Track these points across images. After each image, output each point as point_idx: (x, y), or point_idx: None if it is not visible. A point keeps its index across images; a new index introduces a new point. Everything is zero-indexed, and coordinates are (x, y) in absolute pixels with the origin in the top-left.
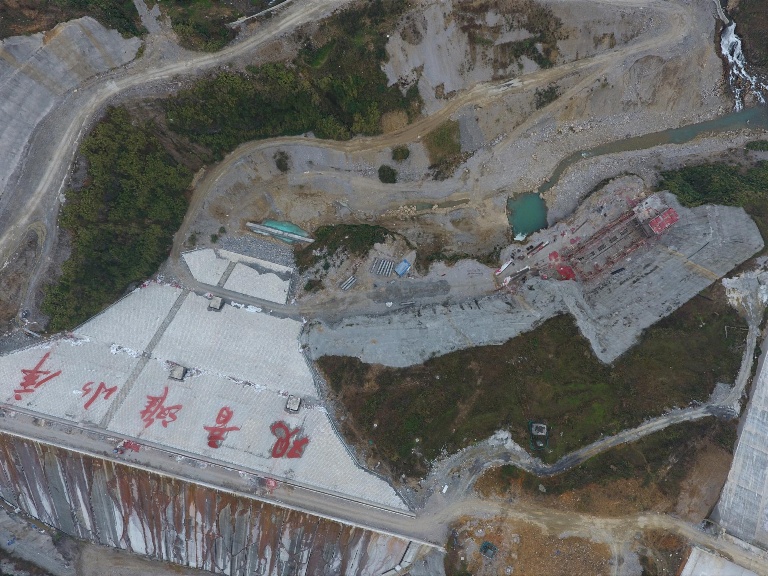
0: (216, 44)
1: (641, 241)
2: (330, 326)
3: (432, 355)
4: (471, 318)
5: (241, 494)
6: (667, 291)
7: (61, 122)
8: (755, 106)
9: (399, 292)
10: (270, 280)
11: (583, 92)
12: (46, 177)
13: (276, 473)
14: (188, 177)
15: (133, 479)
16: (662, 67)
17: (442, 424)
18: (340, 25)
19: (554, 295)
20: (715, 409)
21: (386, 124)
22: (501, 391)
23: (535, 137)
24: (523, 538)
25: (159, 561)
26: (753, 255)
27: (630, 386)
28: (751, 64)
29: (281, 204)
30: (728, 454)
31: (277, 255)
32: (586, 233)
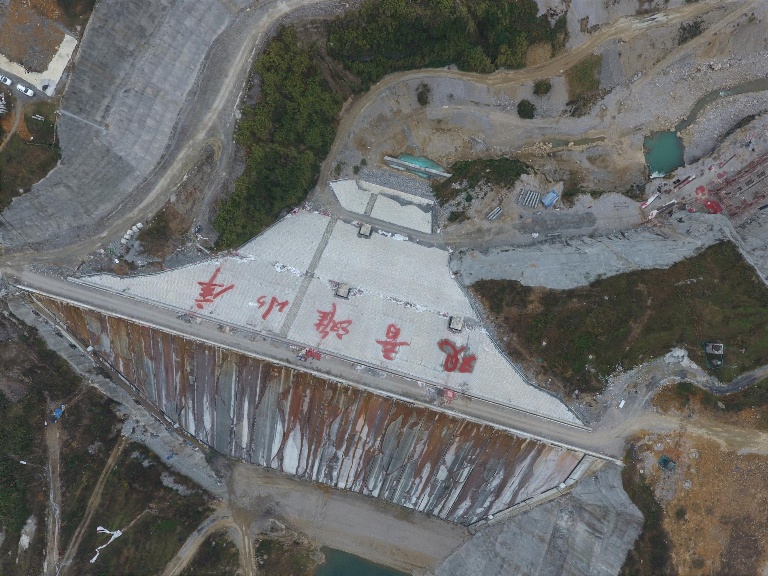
0: None
1: None
2: None
3: (598, 277)
4: (631, 244)
5: (421, 403)
6: None
7: (235, 40)
8: None
9: (545, 223)
10: (412, 211)
11: (729, 27)
12: (222, 94)
13: (452, 385)
14: (339, 105)
15: (308, 389)
16: None
17: (615, 342)
18: None
19: (712, 224)
20: None
21: (530, 57)
22: (672, 312)
23: (674, 74)
24: (702, 453)
25: (308, 481)
26: None
27: None
28: None
29: (419, 138)
30: None
31: (416, 188)
32: (734, 168)
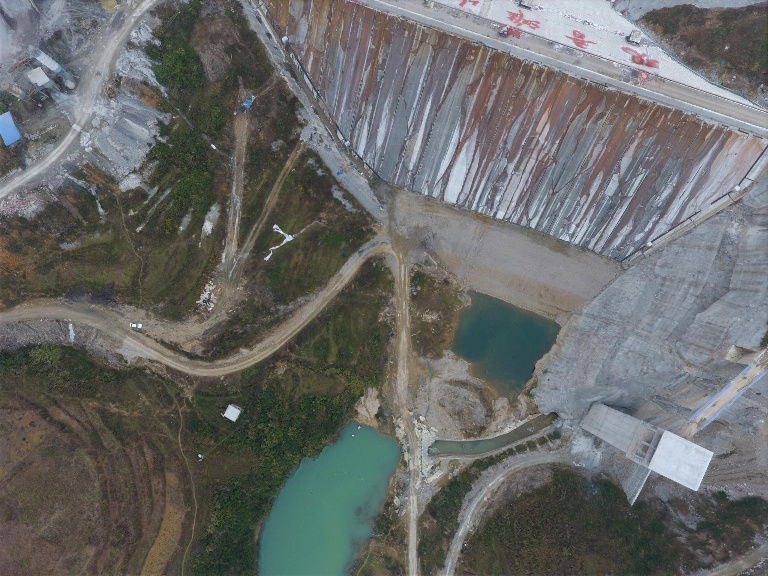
0: None
1: None
2: None
3: None
4: None
5: (618, 80)
6: None
7: None
8: None
9: None
10: None
11: None
12: None
13: None
14: None
15: (500, 77)
16: None
17: None
18: None
19: None
20: None
21: None
22: None
23: None
24: None
25: (467, 211)
26: None
27: None
28: None
29: None
30: None
31: None
32: None
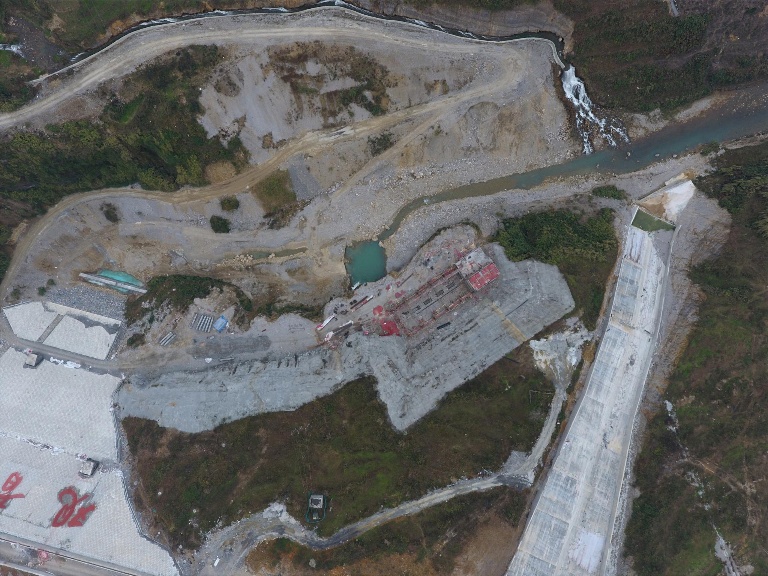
0: (13, 104)
1: (464, 296)
2: (147, 383)
3: (222, 421)
4: (272, 381)
5: (11, 566)
6: (479, 351)
7: None
8: (606, 149)
9: (219, 348)
10: (95, 334)
11: (417, 139)
12: None
13: (51, 544)
14: (4, 233)
15: None
16: (497, 113)
17: (220, 495)
18: (148, 80)
19: (362, 355)
20: (507, 478)
21: (212, 175)
22: (284, 460)
23: (374, 184)
24: None
25: None
26: (563, 316)
27: (418, 455)
28: (600, 106)
29: (114, 254)
30: (511, 527)
31: (107, 307)
32: (412, 287)
